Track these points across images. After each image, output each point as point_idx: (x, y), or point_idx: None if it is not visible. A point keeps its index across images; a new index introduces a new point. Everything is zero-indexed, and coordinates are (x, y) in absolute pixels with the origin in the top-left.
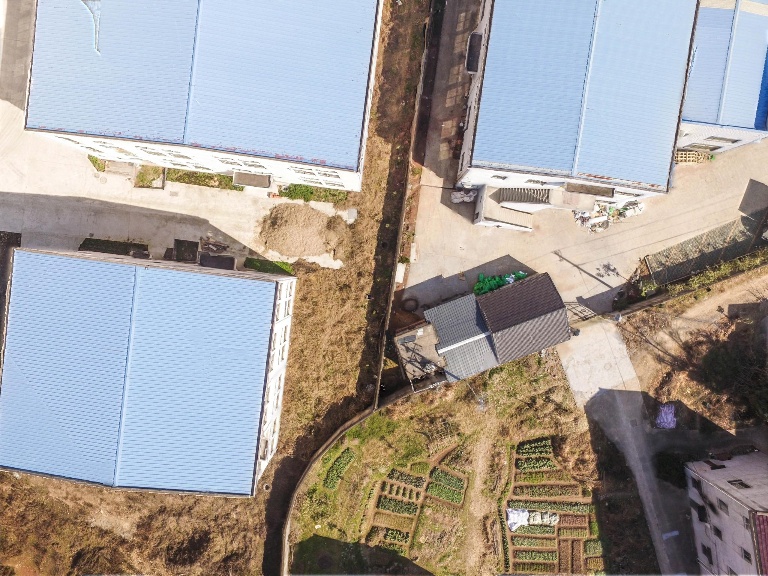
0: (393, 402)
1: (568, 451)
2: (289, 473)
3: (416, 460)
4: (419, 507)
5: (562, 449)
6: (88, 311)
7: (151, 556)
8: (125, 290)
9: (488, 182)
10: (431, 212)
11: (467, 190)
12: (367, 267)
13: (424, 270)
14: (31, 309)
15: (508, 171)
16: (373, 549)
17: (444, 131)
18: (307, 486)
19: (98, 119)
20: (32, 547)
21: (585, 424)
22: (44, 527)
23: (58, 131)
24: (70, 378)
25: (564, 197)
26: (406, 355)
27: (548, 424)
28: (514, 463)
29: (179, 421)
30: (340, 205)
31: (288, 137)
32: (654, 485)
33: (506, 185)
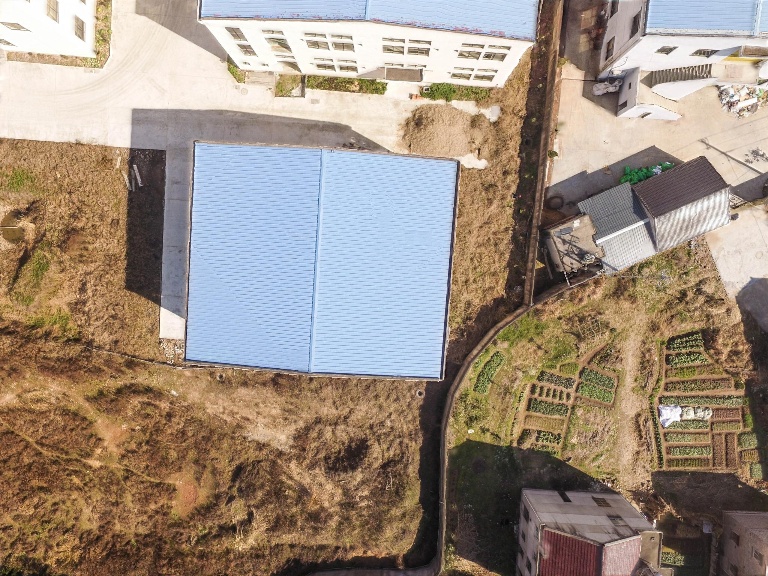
0: None
1: (720, 343)
2: None
3: (565, 361)
4: (570, 408)
5: (715, 341)
6: (274, 199)
7: (309, 466)
8: (311, 175)
9: (644, 63)
10: (573, 106)
11: (612, 79)
12: (512, 165)
13: (568, 166)
14: (216, 201)
15: (686, 35)
16: (526, 451)
17: (584, 21)
18: (459, 390)
19: (275, 2)
20: (191, 464)
21: (738, 314)
22: (203, 442)
23: (235, 17)
24: (259, 268)
25: (727, 71)
26: (563, 248)
27: (699, 317)
28: (664, 359)
29: (369, 306)
30: (483, 103)
31: (468, 8)
32: None
33: (662, 65)
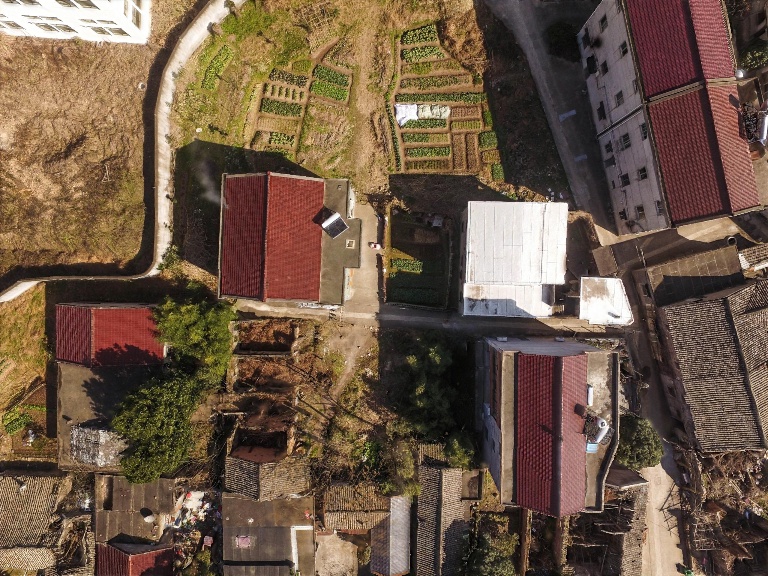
0: None
1: (454, 34)
2: None
3: (297, 58)
4: (303, 108)
5: (446, 28)
6: None
7: (29, 163)
8: None
9: None
10: None
11: None
12: None
13: None
14: None
15: None
16: (258, 153)
17: None
18: (184, 84)
19: None
20: None
21: None
22: None
23: None
24: None
25: None
26: None
27: (431, 8)
28: (399, 54)
29: None
30: None
31: None
32: (547, 63)
33: None
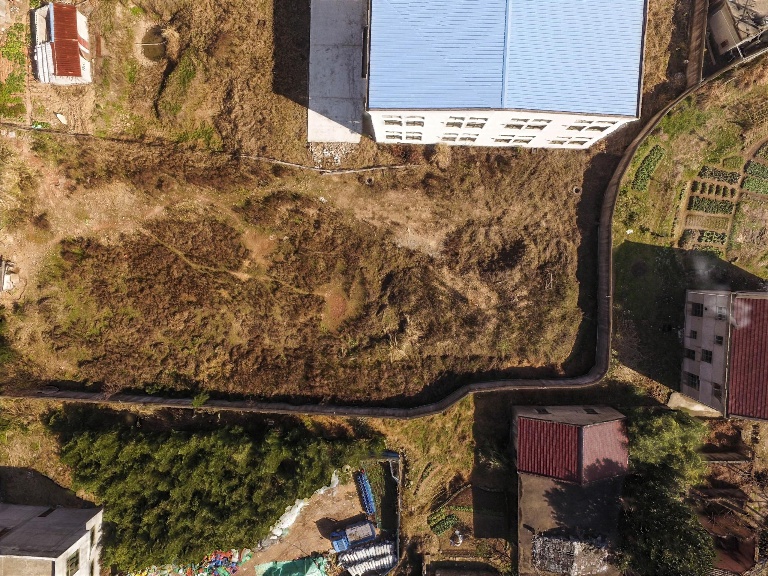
0: (720, 73)
1: None
2: (599, 174)
3: (729, 154)
4: (734, 205)
5: None
6: None
7: (462, 271)
8: None
9: None
10: None
11: None
12: None
13: None
14: None
15: None
16: (688, 252)
17: None
18: None
19: None
20: (340, 274)
21: None
22: (353, 250)
23: None
24: (446, 3)
25: None
26: (738, 13)
27: None
28: None
29: (562, 37)
30: None
31: None
32: None
33: None
